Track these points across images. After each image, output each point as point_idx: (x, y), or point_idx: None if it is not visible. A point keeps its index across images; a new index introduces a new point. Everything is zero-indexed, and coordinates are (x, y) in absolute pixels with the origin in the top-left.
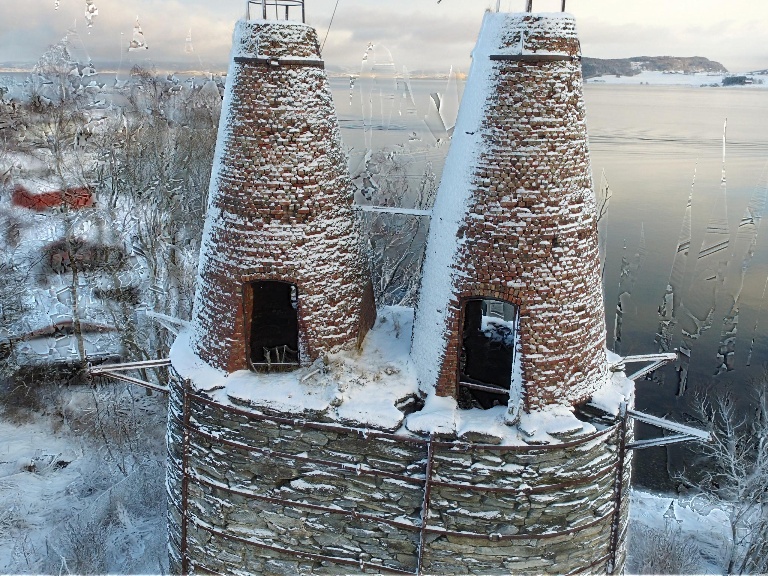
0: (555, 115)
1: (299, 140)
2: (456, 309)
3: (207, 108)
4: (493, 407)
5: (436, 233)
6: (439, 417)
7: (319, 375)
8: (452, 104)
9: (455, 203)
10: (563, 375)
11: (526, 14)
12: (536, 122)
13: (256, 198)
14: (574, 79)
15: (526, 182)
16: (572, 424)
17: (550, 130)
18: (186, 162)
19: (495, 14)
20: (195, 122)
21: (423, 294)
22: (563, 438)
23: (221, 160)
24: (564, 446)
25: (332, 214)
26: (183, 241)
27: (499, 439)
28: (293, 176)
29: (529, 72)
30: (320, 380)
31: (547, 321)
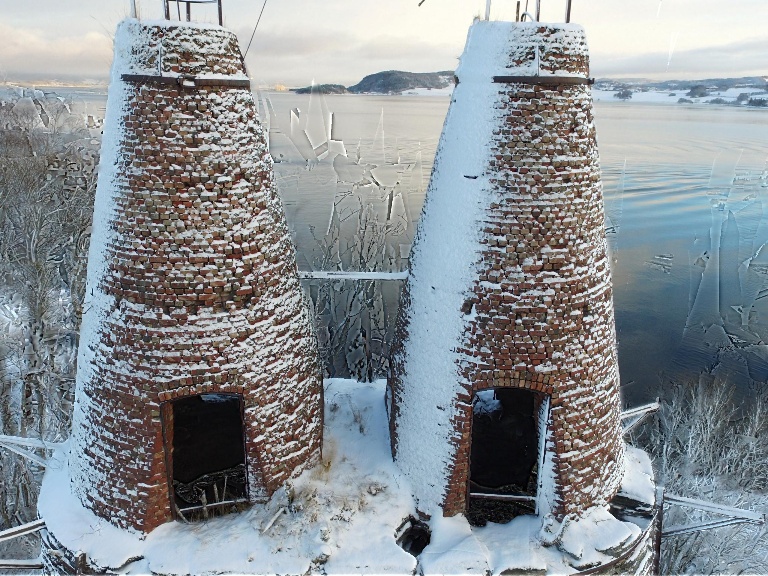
0: (579, 152)
1: (231, 192)
2: (467, 405)
3: (23, 131)
4: (514, 519)
5: (427, 306)
6: (466, 556)
7: (286, 518)
8: (317, 122)
9: (456, 268)
10: (598, 470)
11: (540, 24)
12: (560, 162)
13: (174, 279)
14: (591, 107)
15: (552, 239)
16: (621, 532)
17: (575, 172)
18: (0, 199)
19: (496, 23)
20: (7, 148)
21: (410, 384)
22: (615, 553)
23: (110, 225)
24: (616, 562)
25: (279, 289)
26: (3, 297)
27: (544, 571)
28: (227, 244)
29: (548, 99)
30: (290, 527)
31: (581, 408)
